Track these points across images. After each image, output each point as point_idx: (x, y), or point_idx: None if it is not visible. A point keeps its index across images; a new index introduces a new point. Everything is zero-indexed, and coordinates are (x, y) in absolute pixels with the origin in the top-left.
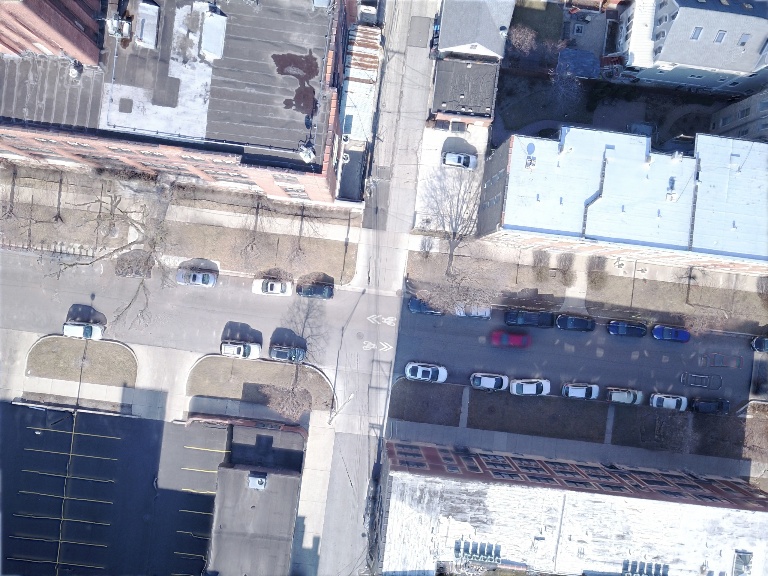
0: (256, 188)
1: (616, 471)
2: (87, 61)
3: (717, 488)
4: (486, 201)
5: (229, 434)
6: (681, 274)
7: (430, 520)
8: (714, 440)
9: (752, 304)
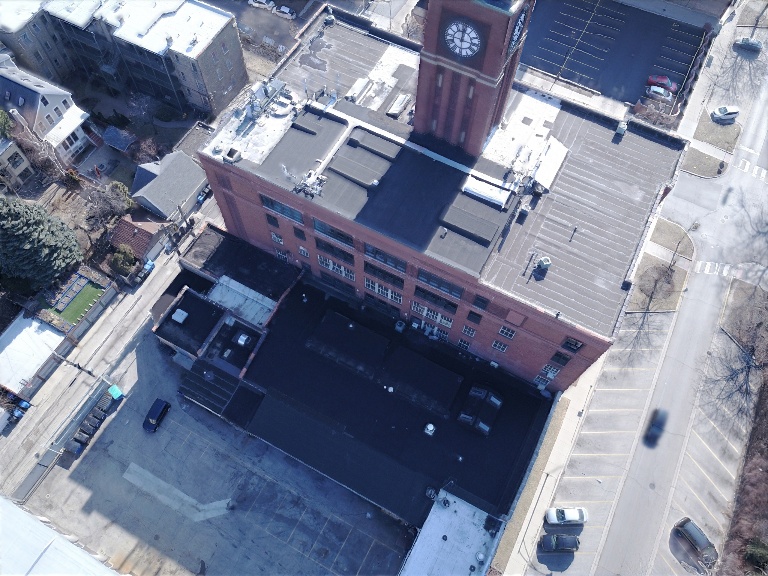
0: None
1: None
2: None
3: None
4: None
5: None
6: None
7: None
8: None
9: None
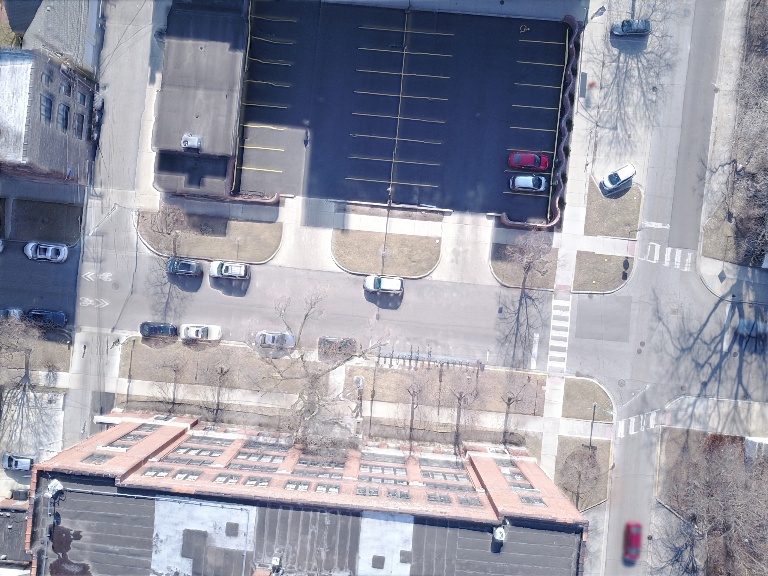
0: (200, 433)
1: None
2: (262, 573)
3: None
4: None
5: (238, 186)
6: None
7: None
8: None
9: None
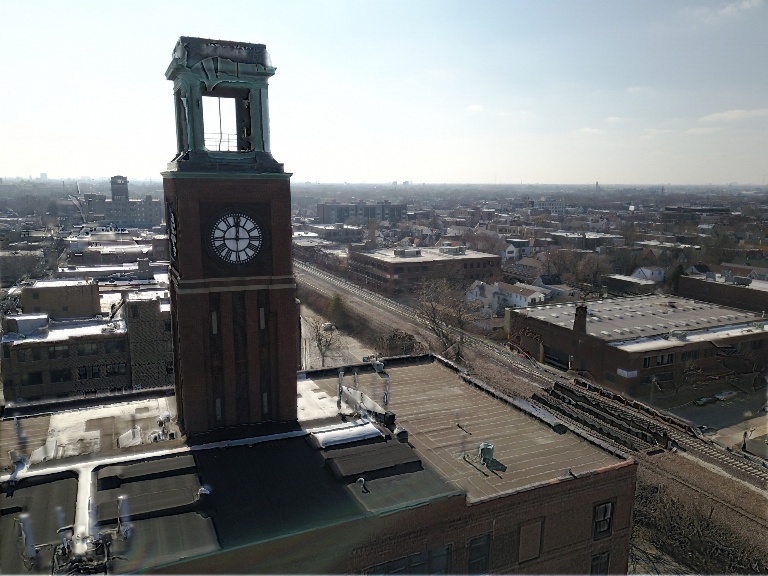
0: None
1: None
2: None
3: None
4: None
5: None
6: None
7: None
8: None
9: None
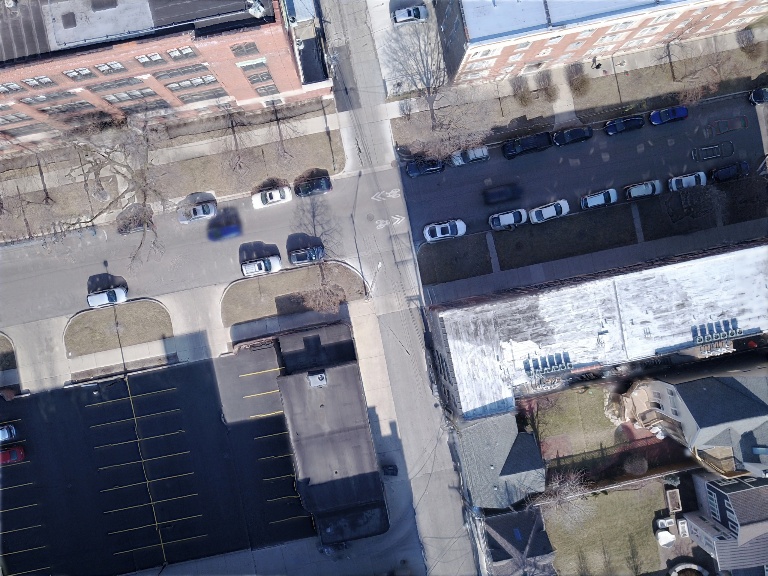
0: (224, 100)
1: (657, 260)
2: None
3: (760, 241)
4: (447, 41)
5: (277, 350)
6: (660, 55)
7: (492, 349)
8: (744, 204)
9: (738, 61)
